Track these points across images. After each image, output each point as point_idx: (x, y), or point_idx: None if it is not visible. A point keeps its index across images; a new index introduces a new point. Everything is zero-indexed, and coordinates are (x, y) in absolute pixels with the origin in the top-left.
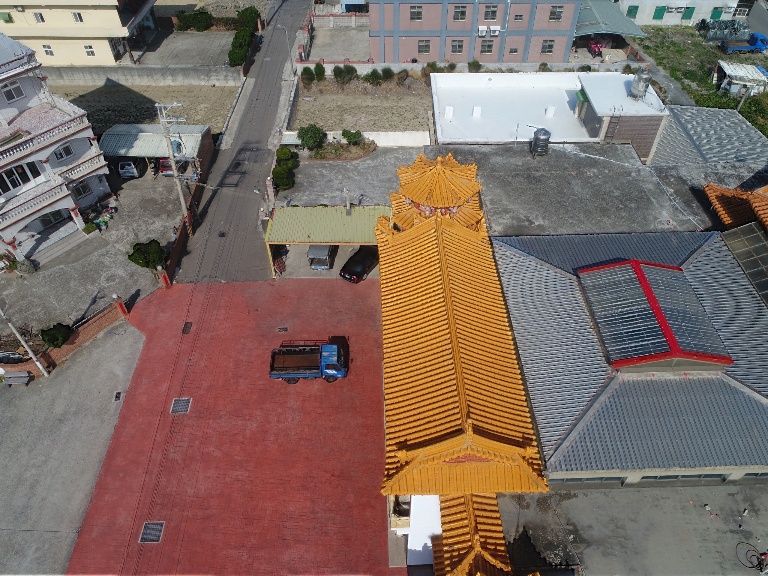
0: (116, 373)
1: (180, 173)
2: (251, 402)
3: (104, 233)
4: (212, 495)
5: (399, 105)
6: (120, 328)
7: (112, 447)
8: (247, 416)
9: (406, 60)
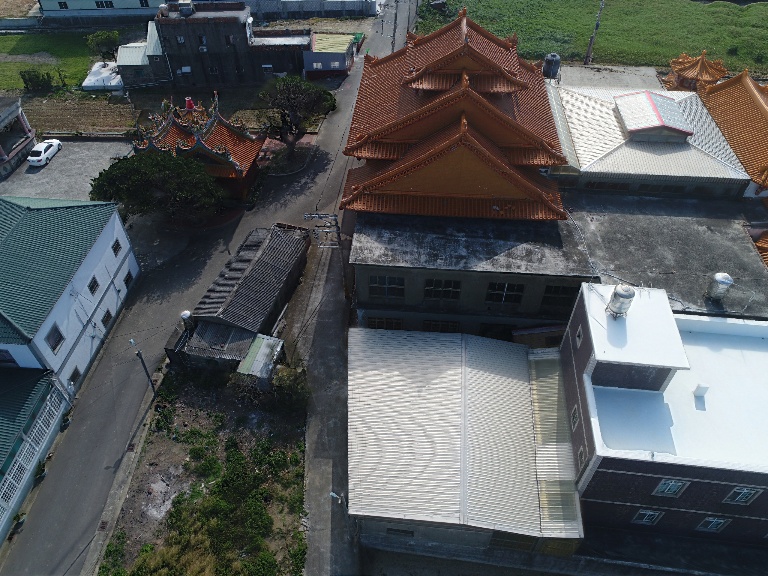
0: None
1: None
2: None
3: None
4: None
5: None
6: None
7: None
8: None
9: None
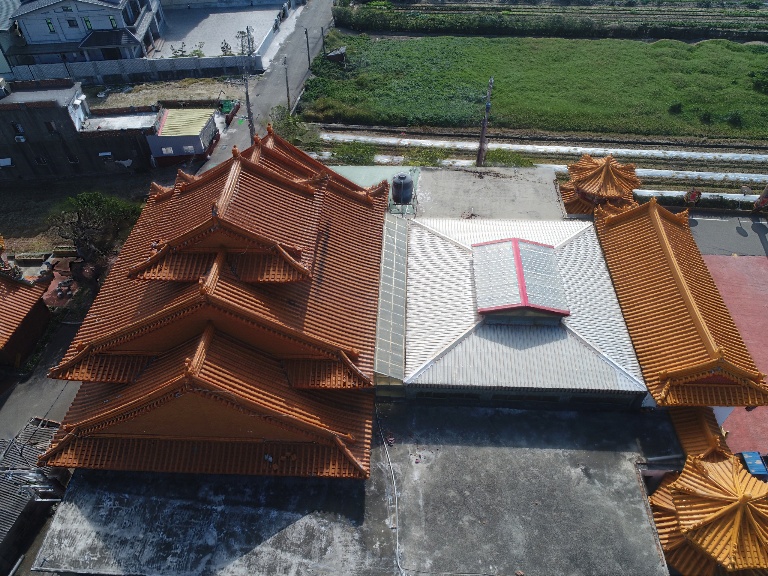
0: None
1: None
2: None
3: None
4: None
5: None
6: None
7: None
8: None
9: None
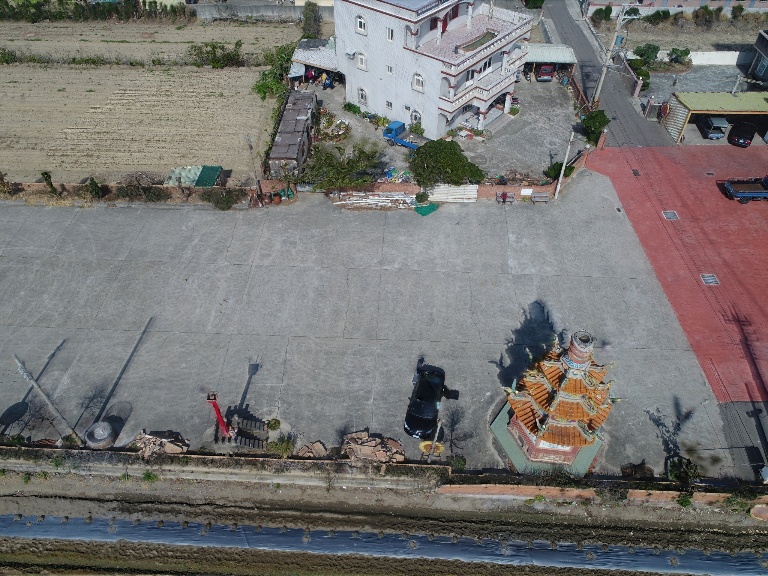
0: (606, 197)
1: (552, 78)
2: (722, 213)
3: (521, 116)
4: (736, 261)
5: (679, 40)
6: (586, 172)
7: (640, 237)
8: (725, 221)
9: (673, 6)
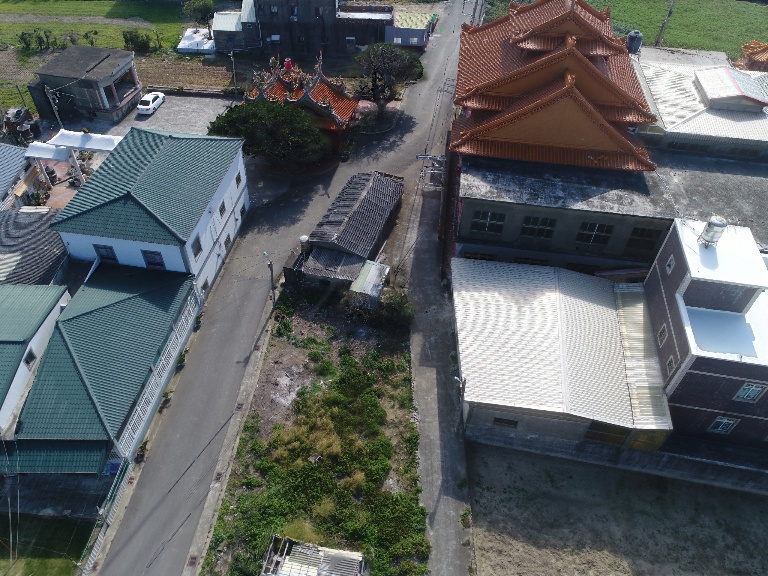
0: None
1: None
2: None
3: None
4: None
5: None
6: None
7: None
8: None
9: None
